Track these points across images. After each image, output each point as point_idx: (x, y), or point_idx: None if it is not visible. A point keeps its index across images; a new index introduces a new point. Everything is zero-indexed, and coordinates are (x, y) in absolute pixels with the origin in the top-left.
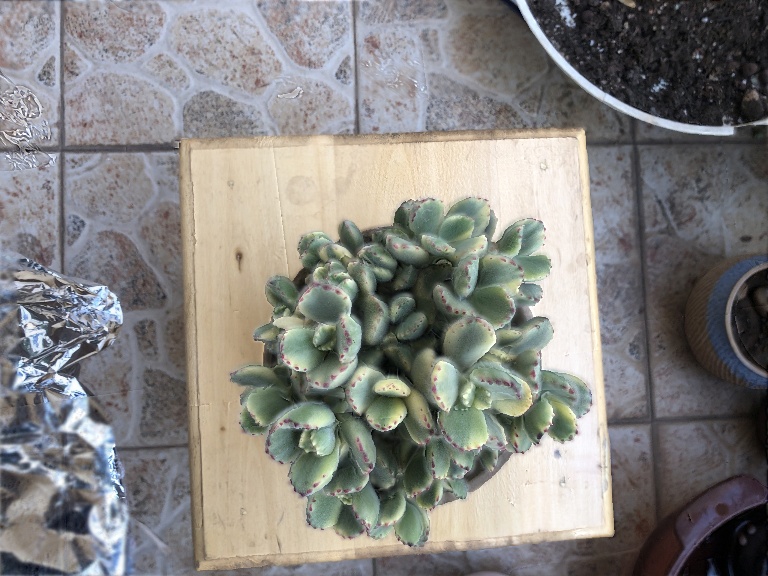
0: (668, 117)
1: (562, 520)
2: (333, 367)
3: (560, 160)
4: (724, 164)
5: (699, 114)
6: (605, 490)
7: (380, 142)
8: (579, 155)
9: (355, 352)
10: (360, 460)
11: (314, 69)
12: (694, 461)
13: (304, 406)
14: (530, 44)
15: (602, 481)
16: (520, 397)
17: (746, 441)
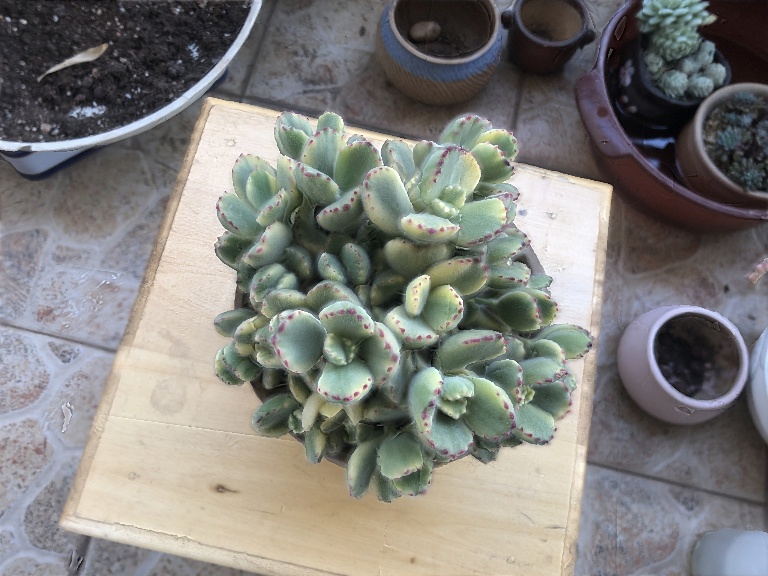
0: (226, 50)
1: (588, 227)
2: (375, 347)
3: (230, 126)
4: (288, 29)
5: (233, 26)
6: (567, 180)
7: (146, 297)
8: (231, 108)
9: (365, 313)
10: (489, 348)
11: (48, 384)
12: (552, 134)
13: (411, 395)
14: (109, 161)
15: (558, 180)
16: (462, 150)
17: (544, 86)
